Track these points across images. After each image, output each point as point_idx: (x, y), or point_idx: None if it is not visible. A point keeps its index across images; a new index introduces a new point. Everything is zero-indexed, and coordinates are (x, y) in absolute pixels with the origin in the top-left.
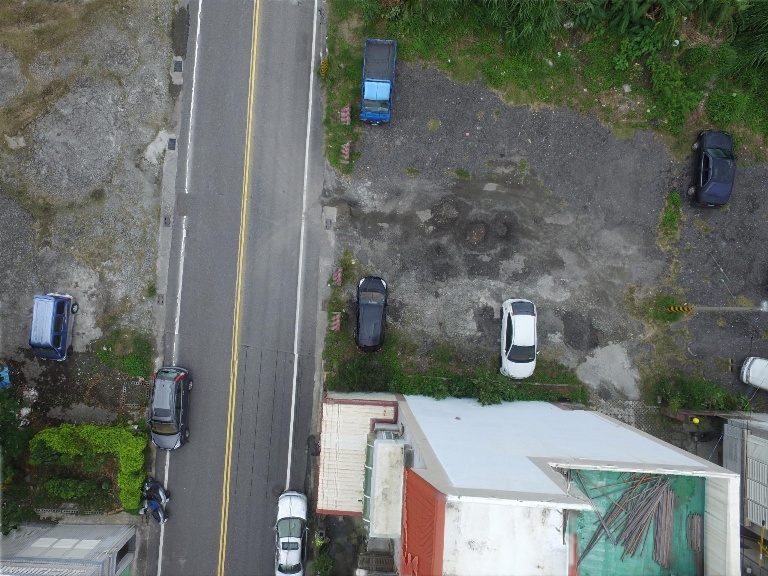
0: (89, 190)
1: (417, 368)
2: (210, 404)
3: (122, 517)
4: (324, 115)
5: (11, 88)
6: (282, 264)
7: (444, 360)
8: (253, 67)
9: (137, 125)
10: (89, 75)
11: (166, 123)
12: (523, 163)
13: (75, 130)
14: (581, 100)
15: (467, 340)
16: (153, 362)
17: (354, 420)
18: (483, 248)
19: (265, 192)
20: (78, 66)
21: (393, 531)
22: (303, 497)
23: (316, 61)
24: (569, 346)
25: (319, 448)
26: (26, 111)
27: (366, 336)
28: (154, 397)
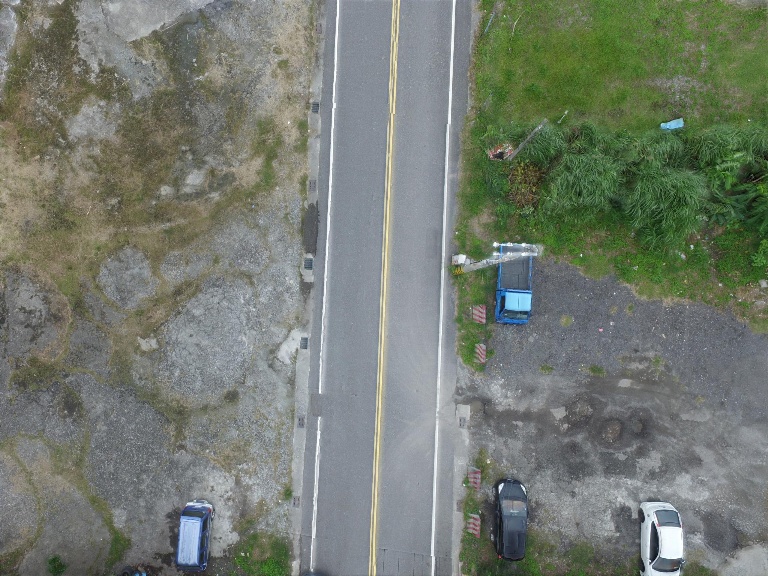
0: (223, 391)
1: (555, 570)
2: None
3: None
4: (456, 311)
5: (143, 290)
6: (417, 465)
7: (582, 562)
8: (385, 266)
9: (269, 325)
10: (220, 275)
11: (297, 321)
12: (658, 359)
13: (207, 331)
14: (716, 295)
15: (605, 541)
16: (290, 566)
17: None
18: (619, 446)
19: (399, 392)
20: (209, 266)
21: None
22: None
23: (446, 256)
24: (709, 547)
25: None
26: (158, 312)
27: (511, 549)
28: None
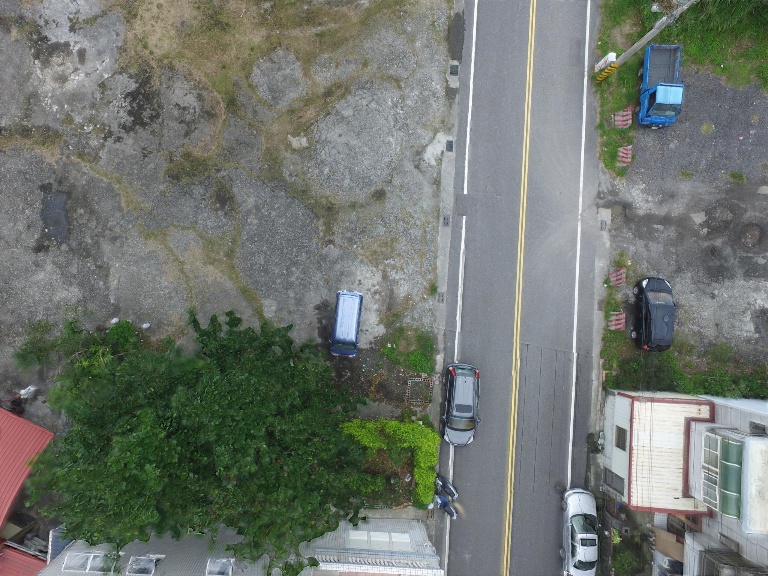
0: (370, 190)
1: (695, 368)
2: (492, 401)
3: (408, 511)
4: (598, 118)
5: (294, 90)
6: (560, 264)
7: (722, 361)
8: (531, 71)
9: (416, 127)
10: (369, 78)
11: (443, 125)
12: None
13: (356, 131)
14: None
15: (744, 341)
16: (434, 359)
17: (668, 418)
18: (758, 250)
19: (543, 193)
20: (358, 69)
21: (767, 527)
22: (591, 494)
23: (589, 65)
24: None
25: (600, 446)
26: (308, 112)
27: (659, 336)
28: (455, 393)
